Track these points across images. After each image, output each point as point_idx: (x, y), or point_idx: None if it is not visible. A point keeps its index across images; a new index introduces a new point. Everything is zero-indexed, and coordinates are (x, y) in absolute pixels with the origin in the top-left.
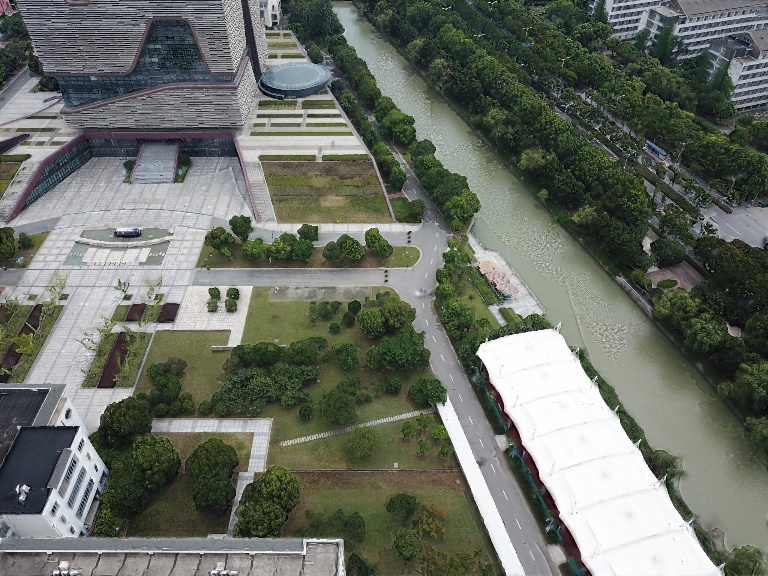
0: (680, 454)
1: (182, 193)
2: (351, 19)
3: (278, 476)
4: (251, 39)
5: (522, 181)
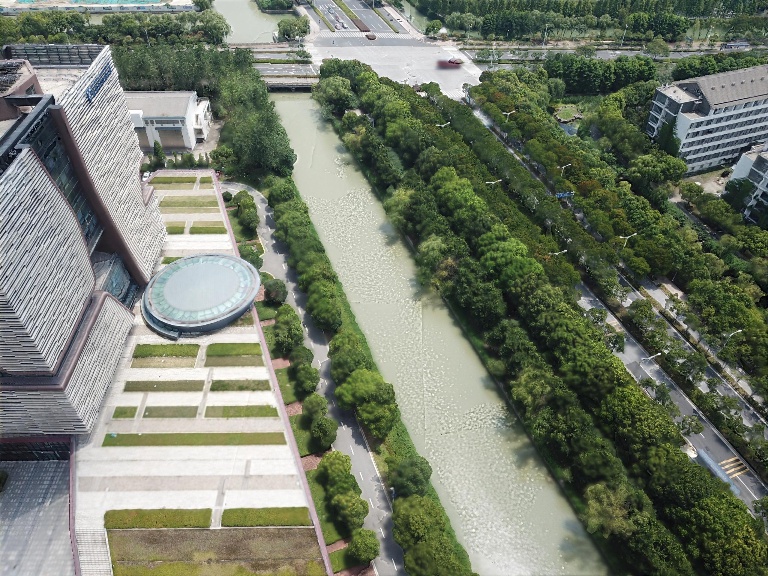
0: None
1: None
2: (310, 127)
3: None
4: (119, 245)
5: (584, 523)
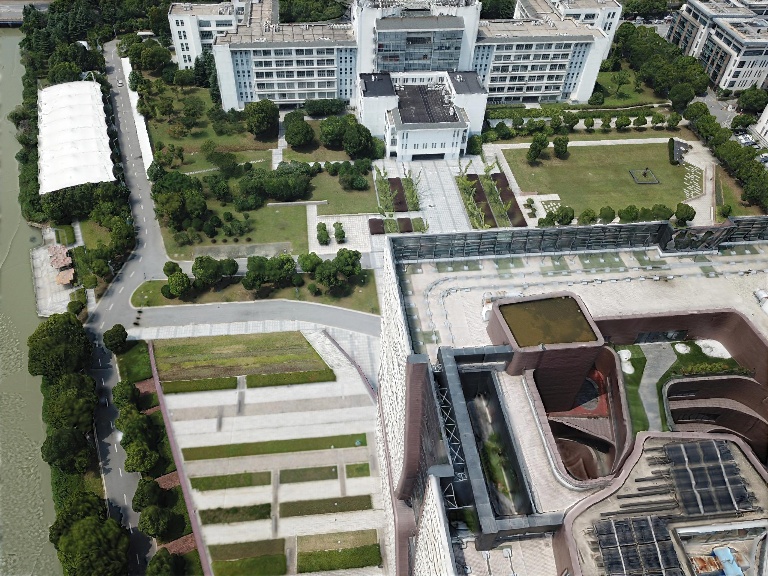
0: None
1: None
2: None
3: (254, 106)
4: None
5: None
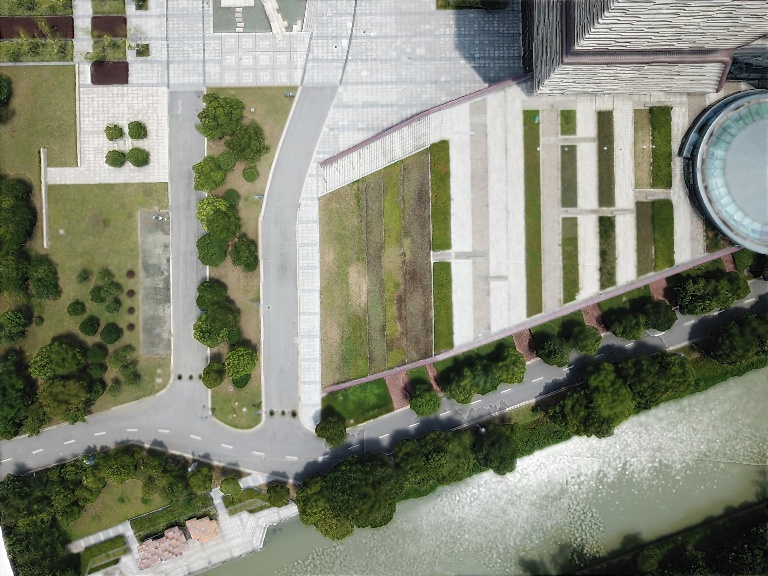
0: None
1: (404, 16)
2: None
3: None
4: None
5: None
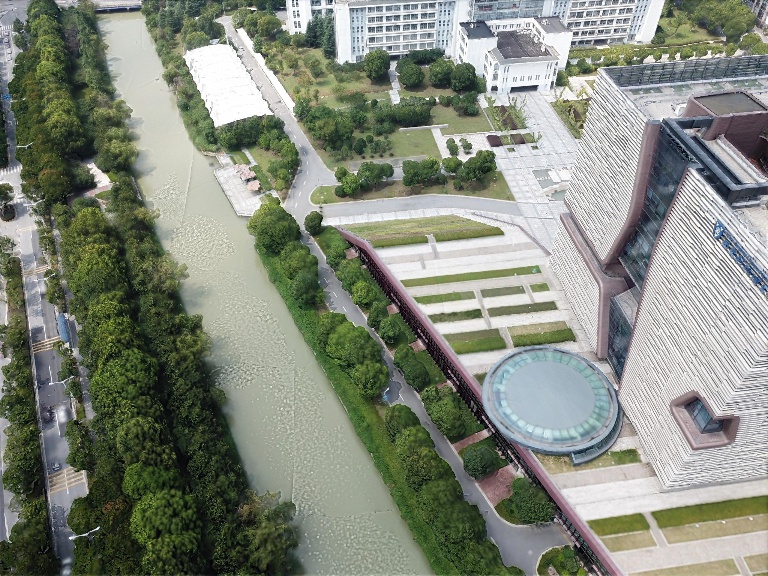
0: (163, 135)
1: None
2: None
3: (373, 53)
4: None
5: None
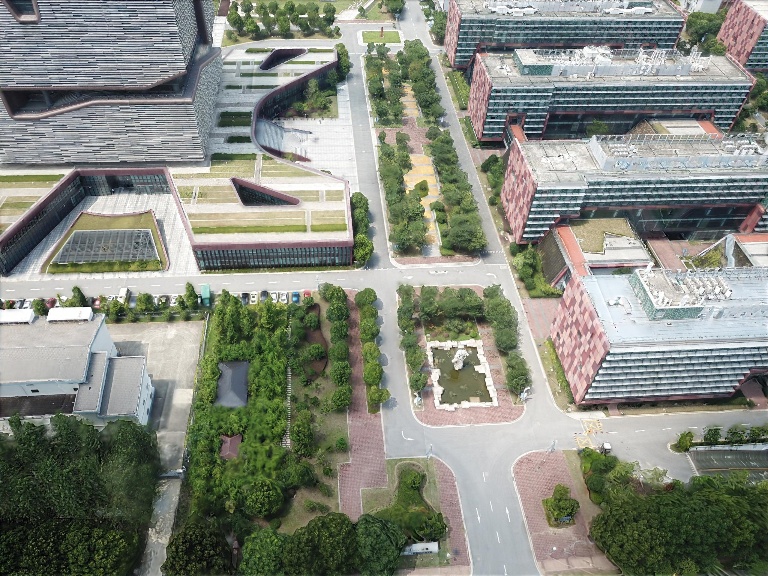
0: None
1: None
2: None
3: None
4: None
5: None
